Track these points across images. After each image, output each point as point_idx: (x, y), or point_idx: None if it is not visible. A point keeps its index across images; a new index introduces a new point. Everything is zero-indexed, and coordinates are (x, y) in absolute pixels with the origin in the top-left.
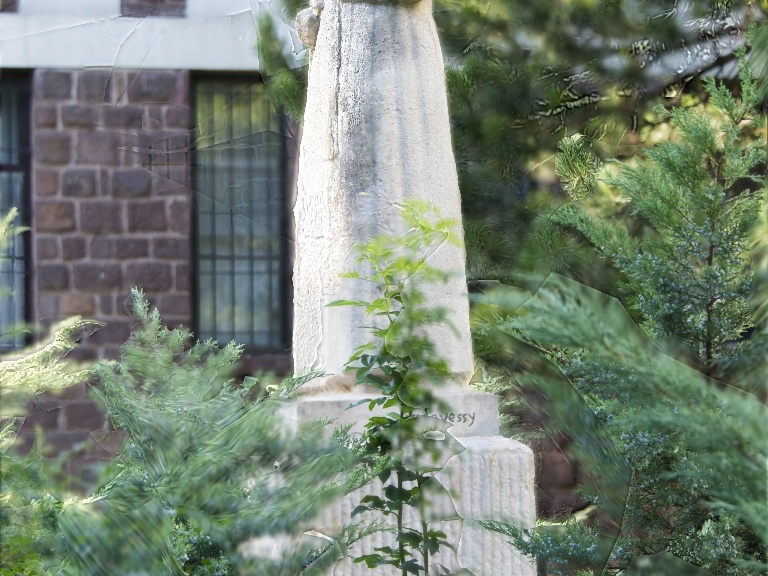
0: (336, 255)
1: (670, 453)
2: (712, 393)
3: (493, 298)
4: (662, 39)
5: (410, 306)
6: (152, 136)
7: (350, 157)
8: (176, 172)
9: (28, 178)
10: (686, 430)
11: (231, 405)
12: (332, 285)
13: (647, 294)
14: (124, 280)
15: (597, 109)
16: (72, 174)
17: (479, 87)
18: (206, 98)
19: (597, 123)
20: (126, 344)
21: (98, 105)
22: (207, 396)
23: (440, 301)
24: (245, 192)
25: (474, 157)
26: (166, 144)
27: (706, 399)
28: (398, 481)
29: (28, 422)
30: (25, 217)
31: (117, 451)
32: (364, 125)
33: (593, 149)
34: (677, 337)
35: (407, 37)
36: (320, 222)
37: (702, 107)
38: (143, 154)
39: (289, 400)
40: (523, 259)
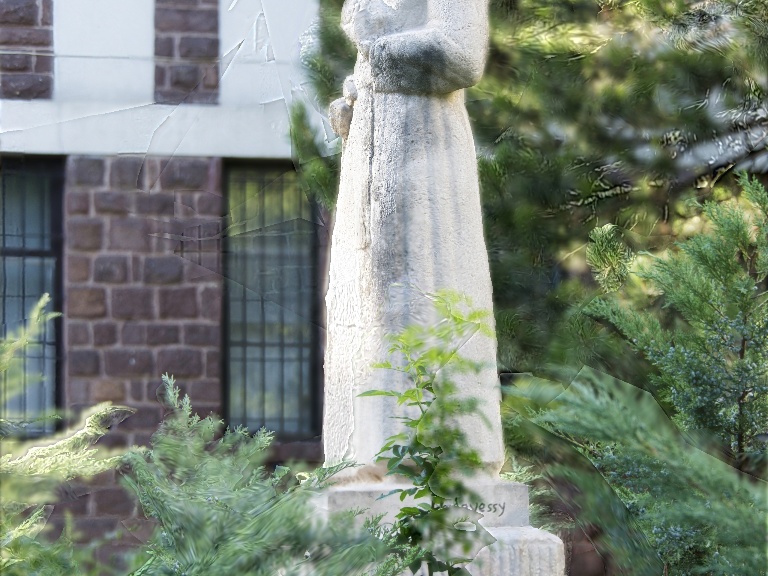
0: (369, 345)
1: (703, 547)
2: (745, 487)
3: (526, 390)
4: (694, 130)
5: (441, 395)
6: (184, 223)
7: (382, 246)
8: (208, 259)
9: (60, 264)
10: (719, 524)
11: (263, 494)
12: (365, 375)
13: (679, 386)
14: (155, 366)
15: (629, 199)
16: (104, 260)
17: (511, 176)
18: (238, 185)
19: (628, 213)
20: (159, 432)
21: (131, 192)
22: (237, 483)
23: (471, 390)
24: (276, 279)
25: (505, 246)
26: (198, 231)
27: (739, 493)
28: (429, 571)
29: (58, 507)
30: (57, 303)
31: (149, 539)
32: (397, 214)
33: (625, 239)
34: (709, 430)
35: (440, 127)
36: (352, 311)
37: (735, 201)
38: (175, 241)
39: (321, 489)
40: (554, 348)
